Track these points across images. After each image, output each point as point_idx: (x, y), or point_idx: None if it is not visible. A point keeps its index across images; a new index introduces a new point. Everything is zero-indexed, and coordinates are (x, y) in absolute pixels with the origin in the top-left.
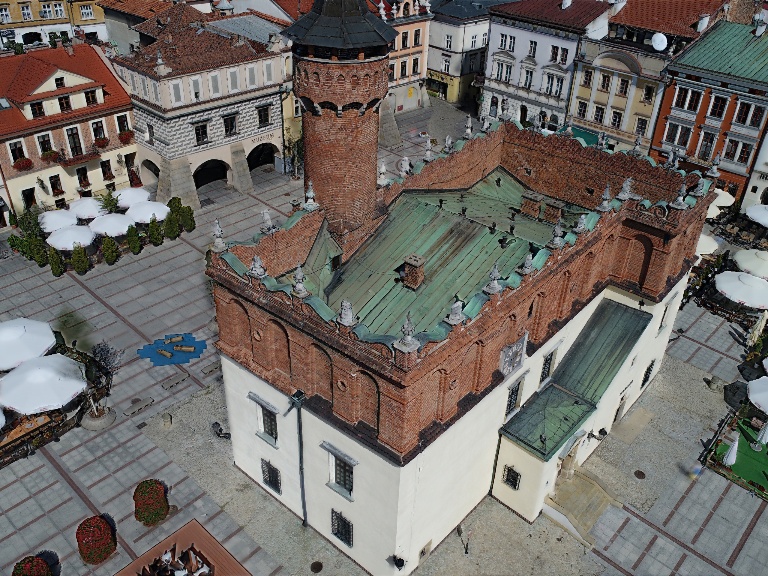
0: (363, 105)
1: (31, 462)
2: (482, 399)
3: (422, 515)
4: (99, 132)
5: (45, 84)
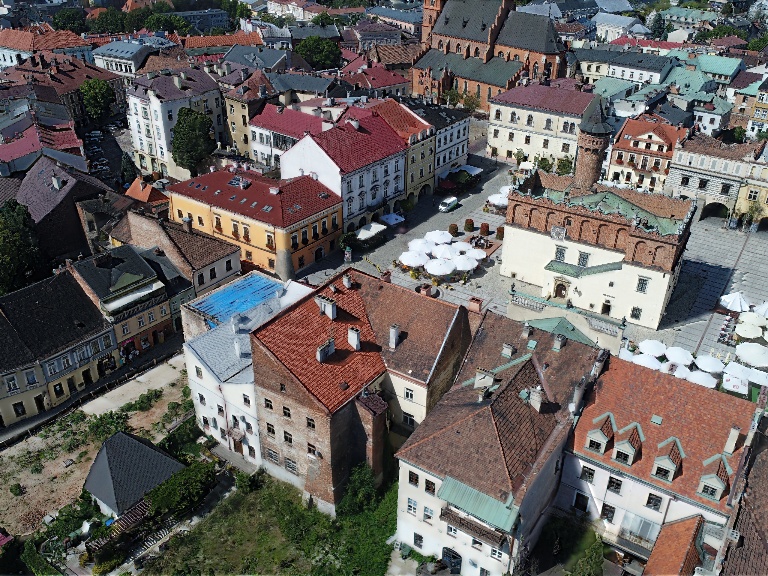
0: None
1: (504, 218)
2: (541, 235)
3: (513, 256)
4: (658, 164)
5: (644, 135)
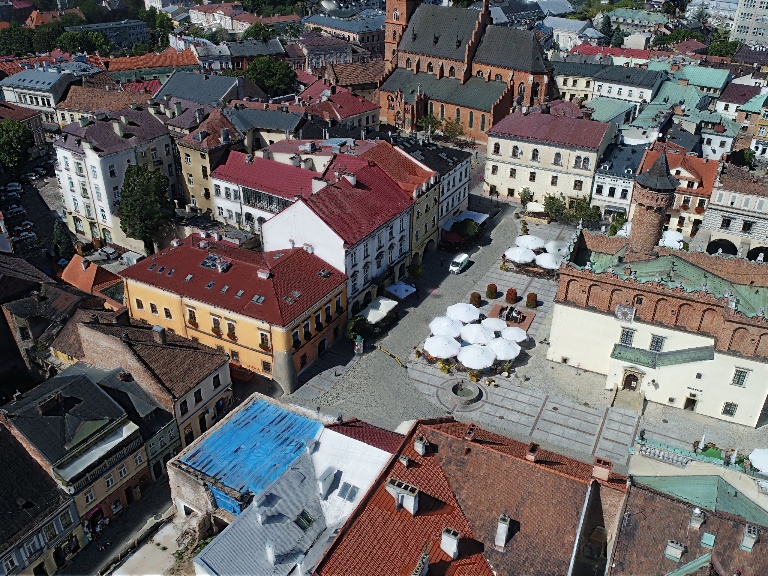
0: (645, 206)
1: (527, 278)
2: (602, 315)
3: (565, 338)
4: (687, 202)
5: (671, 171)
